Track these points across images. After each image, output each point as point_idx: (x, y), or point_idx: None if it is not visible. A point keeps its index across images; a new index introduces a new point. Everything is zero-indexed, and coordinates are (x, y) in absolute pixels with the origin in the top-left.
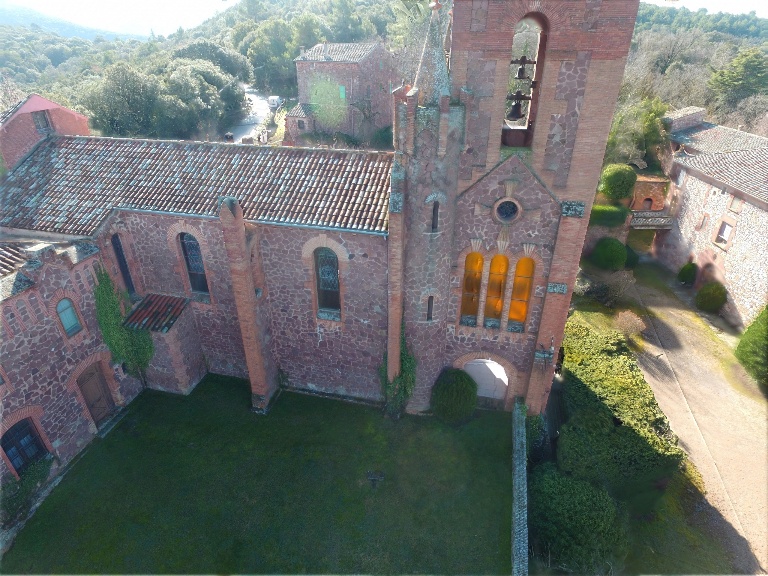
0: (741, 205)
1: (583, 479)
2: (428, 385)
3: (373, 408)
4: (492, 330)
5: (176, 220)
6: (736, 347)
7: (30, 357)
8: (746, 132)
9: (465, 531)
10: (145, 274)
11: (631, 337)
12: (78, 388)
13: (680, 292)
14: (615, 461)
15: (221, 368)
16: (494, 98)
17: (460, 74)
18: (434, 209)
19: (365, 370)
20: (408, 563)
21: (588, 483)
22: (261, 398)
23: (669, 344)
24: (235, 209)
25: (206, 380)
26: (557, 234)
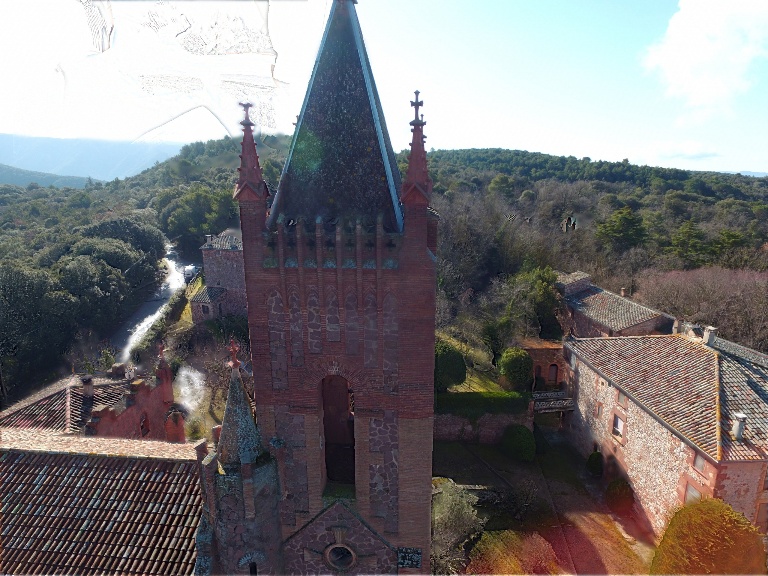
0: (626, 402)
1: None
2: None
3: None
4: None
5: None
6: (651, 564)
7: None
8: (627, 300)
9: None
10: None
11: (544, 564)
12: None
13: (591, 485)
14: None
15: None
16: (307, 449)
17: (268, 426)
18: (251, 569)
19: None
20: None
21: None
22: None
23: (584, 569)
24: None
25: None
26: None
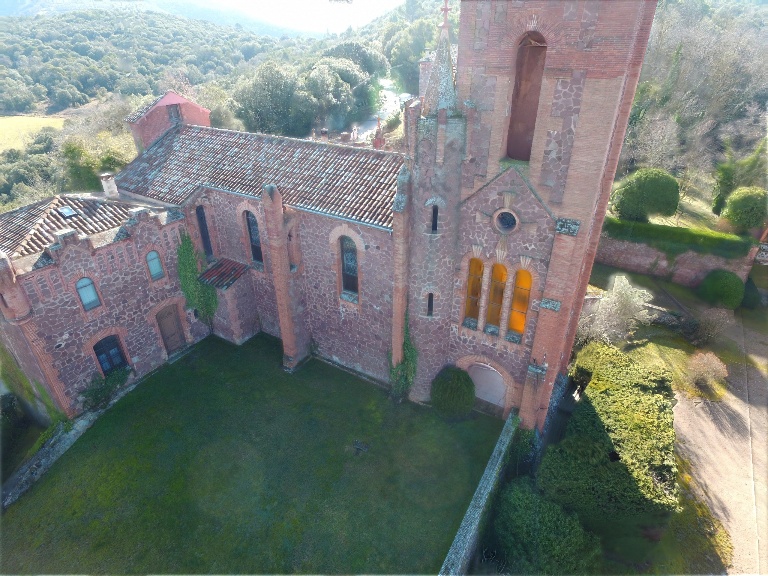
0: None
1: (555, 501)
2: (429, 377)
3: (381, 389)
4: (491, 336)
5: (242, 199)
6: None
7: (122, 290)
8: None
9: (421, 514)
10: (221, 241)
11: (710, 383)
12: (156, 321)
13: None
14: (593, 493)
15: (270, 329)
16: (494, 112)
17: (464, 88)
18: (434, 212)
19: (377, 352)
20: (362, 525)
21: (557, 506)
22: (289, 359)
23: (759, 400)
24: (273, 195)
25: (257, 336)
26: (552, 250)
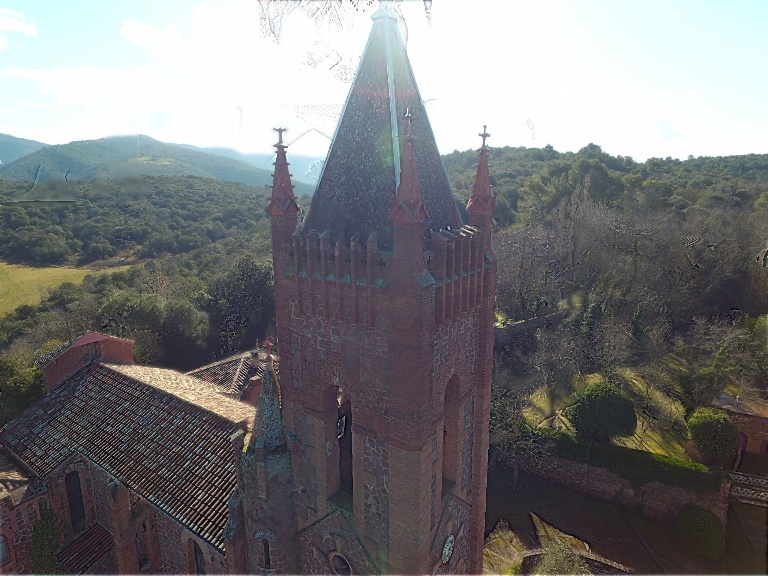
0: None
1: None
2: None
3: None
4: None
5: None
6: None
7: None
8: None
9: None
10: (96, 505)
11: None
12: None
13: None
14: None
15: None
16: (316, 450)
17: (289, 420)
18: (266, 545)
19: None
20: None
21: None
22: None
23: None
24: (117, 494)
25: None
26: None
